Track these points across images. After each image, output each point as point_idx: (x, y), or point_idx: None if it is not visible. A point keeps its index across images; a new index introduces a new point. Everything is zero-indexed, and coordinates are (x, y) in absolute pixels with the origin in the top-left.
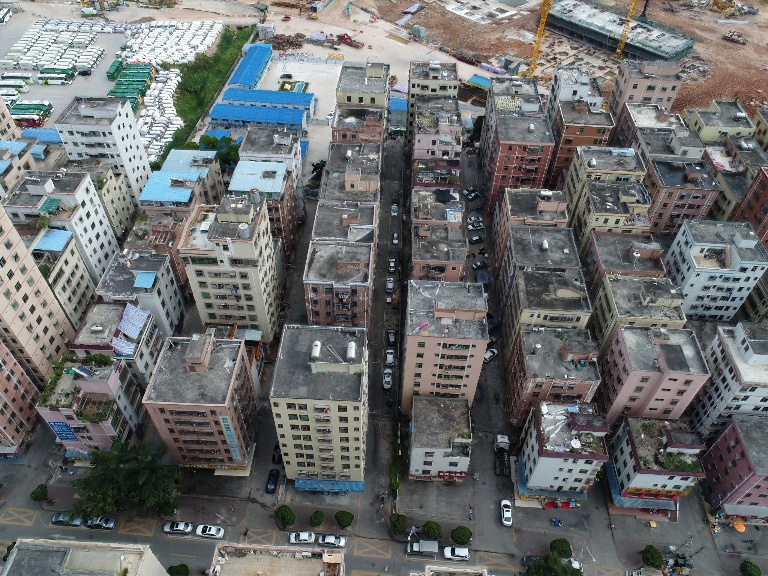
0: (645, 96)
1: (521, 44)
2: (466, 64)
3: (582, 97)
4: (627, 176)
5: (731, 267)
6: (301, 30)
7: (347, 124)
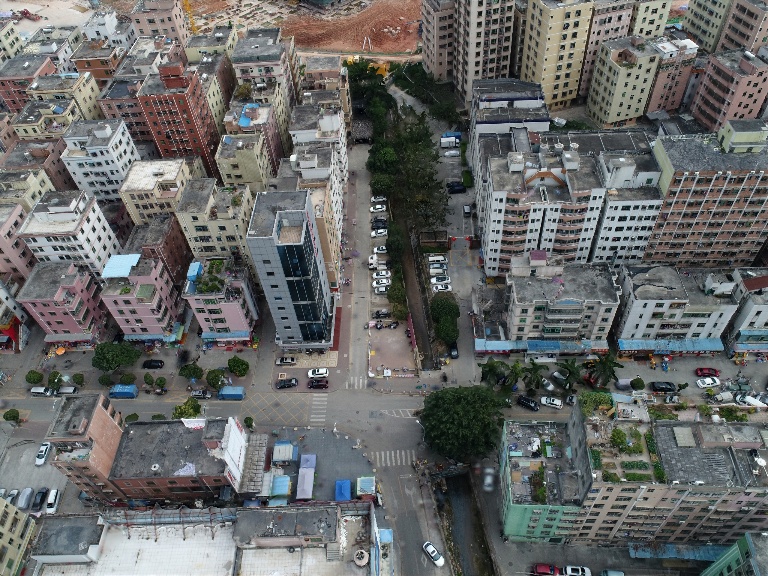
0: (151, 29)
1: (215, 1)
2: None
3: (106, 36)
4: (60, 94)
5: None
6: None
7: None
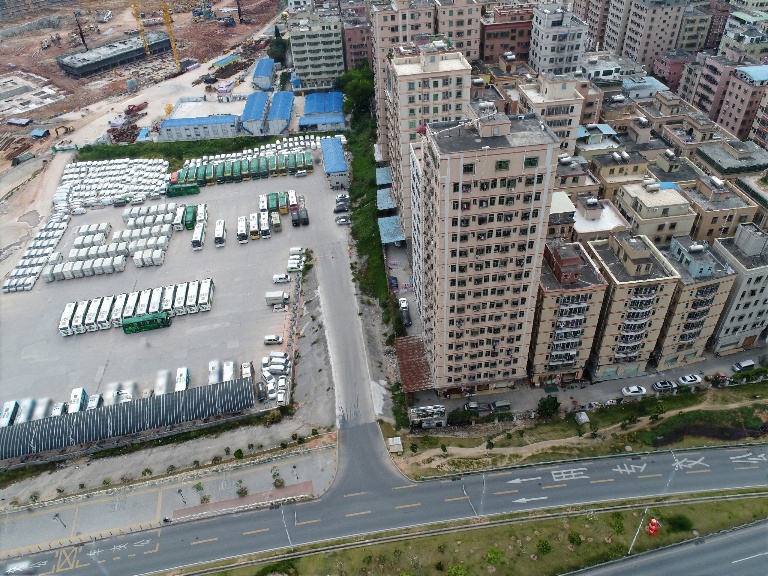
0: None
1: (114, 84)
2: (182, 75)
3: None
4: None
5: None
6: (96, 133)
7: None
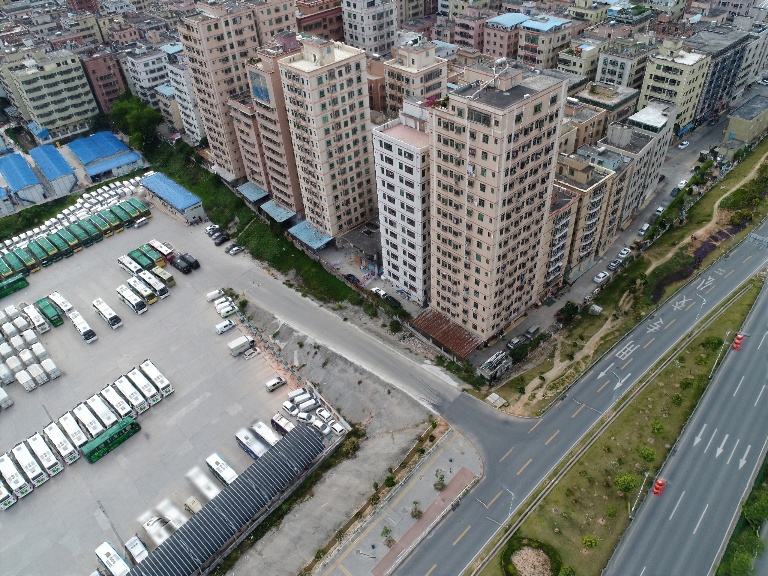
0: None
1: None
2: None
3: None
4: None
5: (128, 4)
6: None
7: (102, 54)
